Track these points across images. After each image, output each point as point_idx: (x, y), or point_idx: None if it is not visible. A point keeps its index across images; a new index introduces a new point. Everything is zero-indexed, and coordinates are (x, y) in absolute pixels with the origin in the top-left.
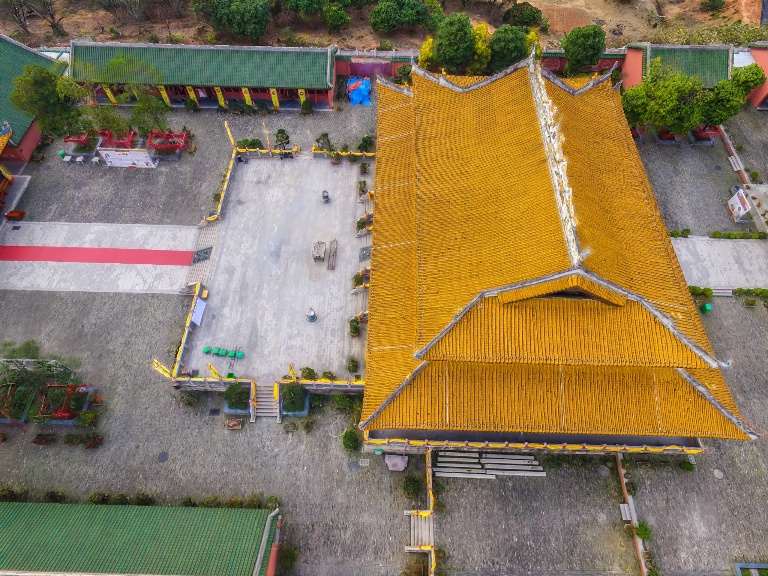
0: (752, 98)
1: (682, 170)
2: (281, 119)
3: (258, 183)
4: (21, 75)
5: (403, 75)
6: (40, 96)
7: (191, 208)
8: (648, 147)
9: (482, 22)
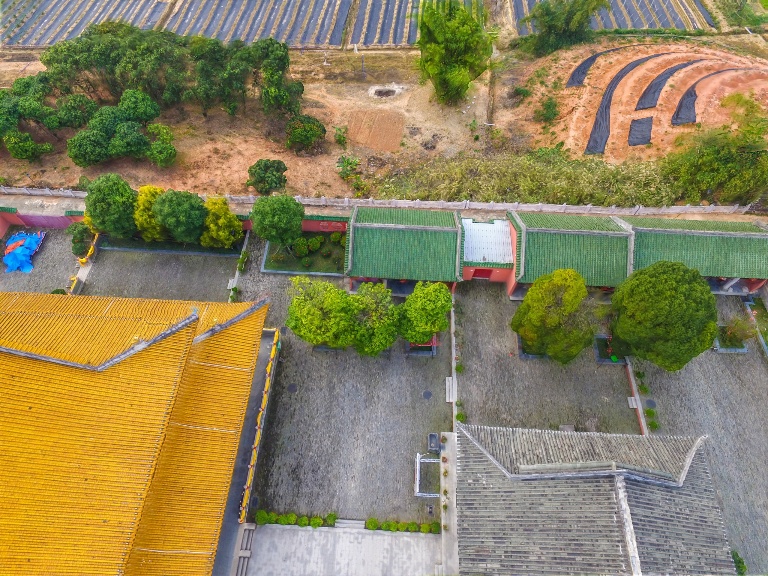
0: (506, 282)
1: (377, 398)
2: None
3: None
4: None
5: None
6: None
7: None
8: (348, 357)
9: (250, 138)
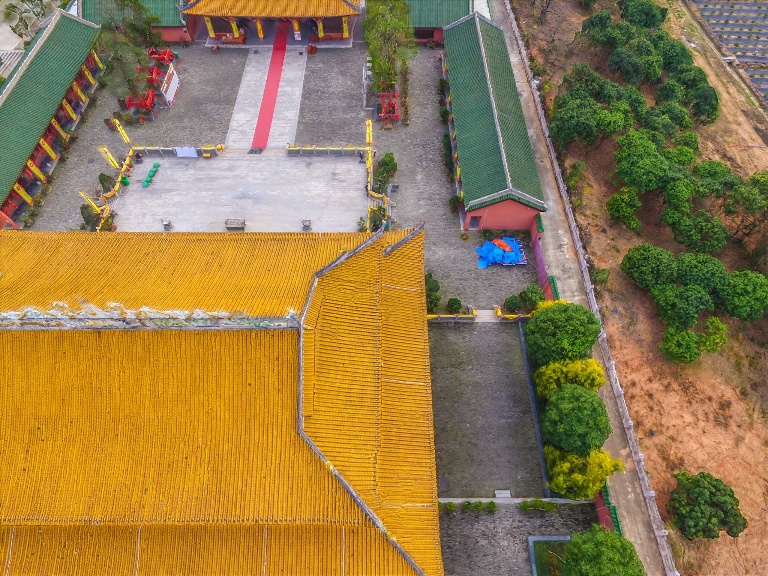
0: None
1: None
2: (440, 186)
3: (333, 174)
4: (439, 4)
5: (527, 294)
6: (374, 6)
7: (315, 139)
8: None
9: None
